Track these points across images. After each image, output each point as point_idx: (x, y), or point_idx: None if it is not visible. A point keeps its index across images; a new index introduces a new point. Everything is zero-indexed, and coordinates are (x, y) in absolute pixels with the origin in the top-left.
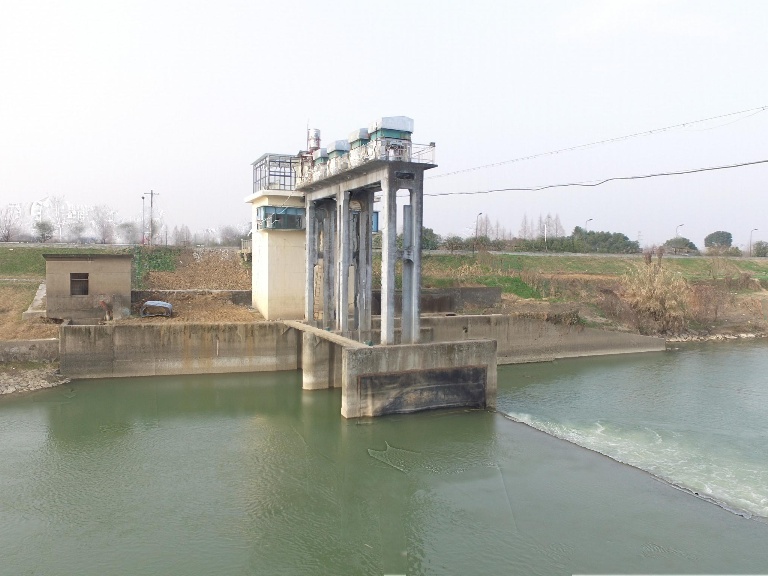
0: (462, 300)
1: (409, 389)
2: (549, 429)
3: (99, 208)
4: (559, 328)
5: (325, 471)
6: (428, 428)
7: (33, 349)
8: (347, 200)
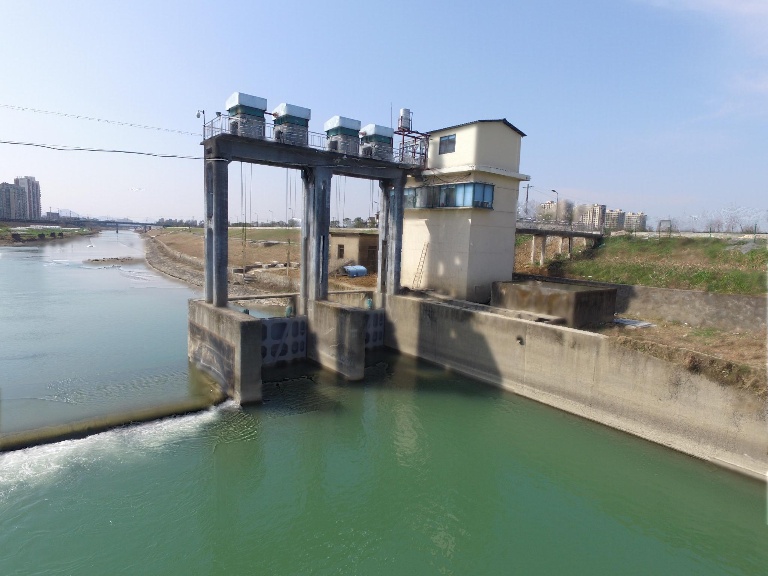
0: (754, 319)
1: None
2: (180, 430)
3: (529, 202)
4: (732, 397)
5: (316, 417)
6: None
7: None
8: (303, 178)
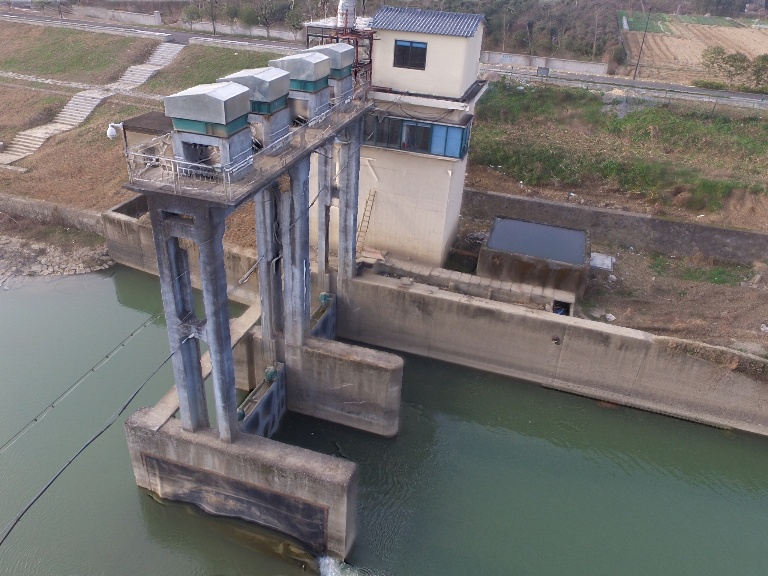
0: (690, 243)
1: (209, 488)
2: None
3: None
4: (762, 388)
5: None
6: (223, 542)
7: (99, 223)
8: None
